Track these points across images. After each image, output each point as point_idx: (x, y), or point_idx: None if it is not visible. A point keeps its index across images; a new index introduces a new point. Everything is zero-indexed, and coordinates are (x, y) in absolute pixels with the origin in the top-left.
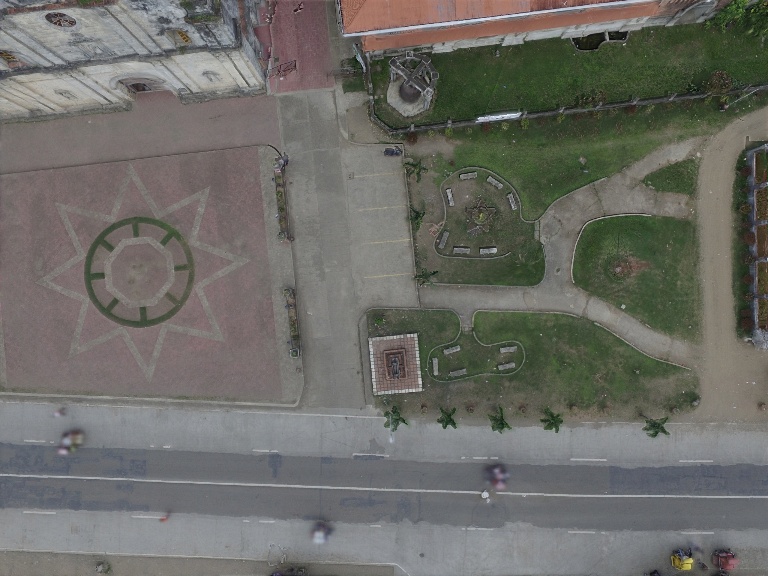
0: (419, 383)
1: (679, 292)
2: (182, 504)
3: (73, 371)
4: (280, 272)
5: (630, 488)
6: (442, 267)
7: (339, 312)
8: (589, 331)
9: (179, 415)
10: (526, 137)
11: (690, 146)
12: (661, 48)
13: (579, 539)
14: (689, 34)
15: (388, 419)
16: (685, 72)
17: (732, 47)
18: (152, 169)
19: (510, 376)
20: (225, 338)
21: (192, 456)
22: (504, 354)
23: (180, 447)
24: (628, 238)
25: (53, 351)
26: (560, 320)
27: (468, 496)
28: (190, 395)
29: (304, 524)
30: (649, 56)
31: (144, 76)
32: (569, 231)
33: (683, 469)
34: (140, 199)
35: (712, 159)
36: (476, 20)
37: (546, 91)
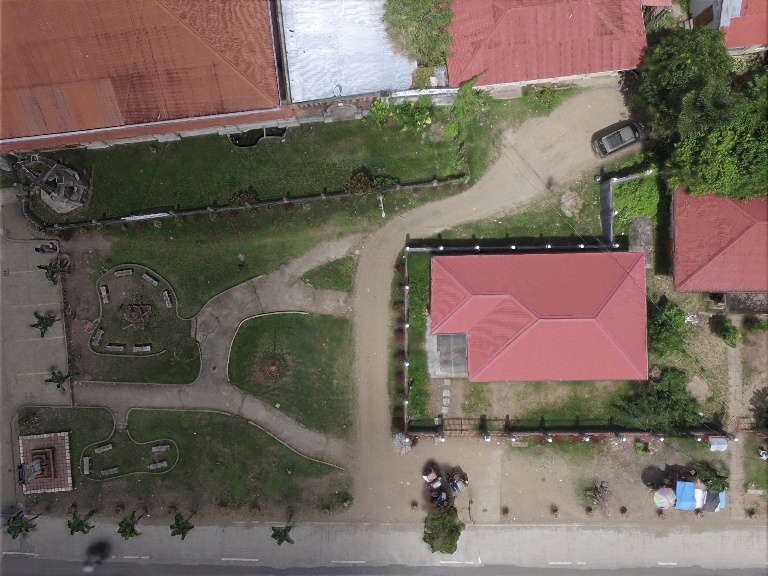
0: (68, 482)
1: (335, 391)
2: None
3: None
4: None
5: None
6: (97, 364)
7: None
8: (243, 430)
9: None
10: (184, 233)
11: (350, 243)
12: (321, 144)
13: None
14: (348, 130)
15: None
16: (344, 169)
17: (391, 144)
18: None
19: (163, 475)
20: None
21: None
22: (158, 452)
23: None
24: (285, 336)
25: None
26: (214, 419)
27: None
28: None
29: None
30: (309, 152)
31: None
32: (226, 328)
33: (335, 570)
34: None
35: (371, 257)
36: (70, 133)
37: (203, 188)
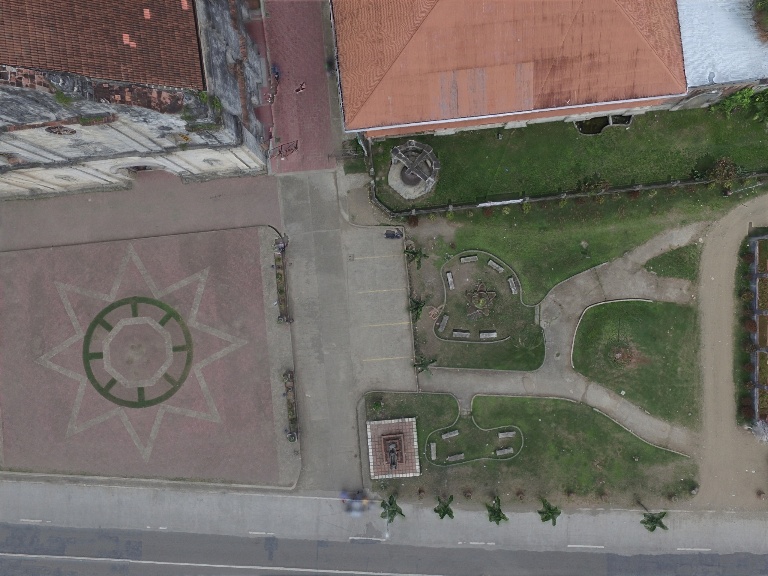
0: (417, 468)
1: (679, 379)
2: None
3: (70, 451)
4: (279, 354)
5: (627, 575)
6: (441, 350)
7: (337, 395)
8: (588, 417)
9: (176, 496)
10: (527, 220)
11: (692, 231)
12: (665, 132)
13: None
14: (693, 119)
15: (385, 509)
16: (688, 157)
17: (736, 132)
18: (152, 249)
19: (508, 461)
20: (223, 420)
21: (188, 537)
22: (502, 439)
23: (176, 528)
24: (629, 324)
25: (51, 430)
26: (559, 405)
27: None
28: (187, 476)
29: None
30: (652, 140)
31: (144, 164)
32: (569, 316)
33: (681, 557)
34: (139, 279)
35: (714, 245)
36: (478, 117)
37: (548, 175)
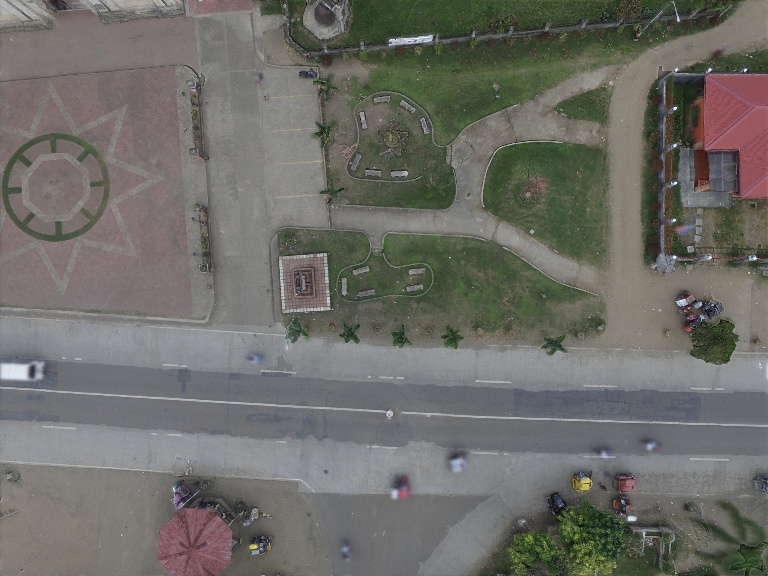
0: (327, 302)
1: (588, 219)
2: (92, 415)
3: None
4: (194, 190)
5: (534, 411)
6: (354, 189)
7: (251, 231)
8: (497, 255)
9: (91, 328)
10: (440, 63)
11: (603, 75)
12: None
13: (482, 460)
14: None
15: None
16: (599, 1)
17: None
18: (71, 87)
19: (418, 298)
20: (138, 254)
21: (103, 369)
22: (413, 276)
23: (91, 360)
24: (539, 164)
25: None
26: (469, 244)
27: (373, 415)
28: (102, 309)
29: (211, 438)
30: None
31: None
32: (481, 156)
33: (587, 393)
34: (58, 116)
35: (624, 88)
36: None
37: (461, 17)
